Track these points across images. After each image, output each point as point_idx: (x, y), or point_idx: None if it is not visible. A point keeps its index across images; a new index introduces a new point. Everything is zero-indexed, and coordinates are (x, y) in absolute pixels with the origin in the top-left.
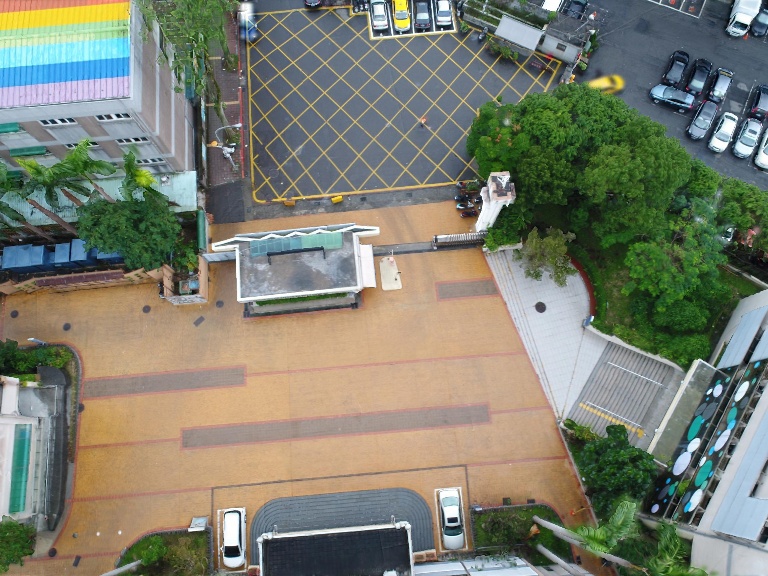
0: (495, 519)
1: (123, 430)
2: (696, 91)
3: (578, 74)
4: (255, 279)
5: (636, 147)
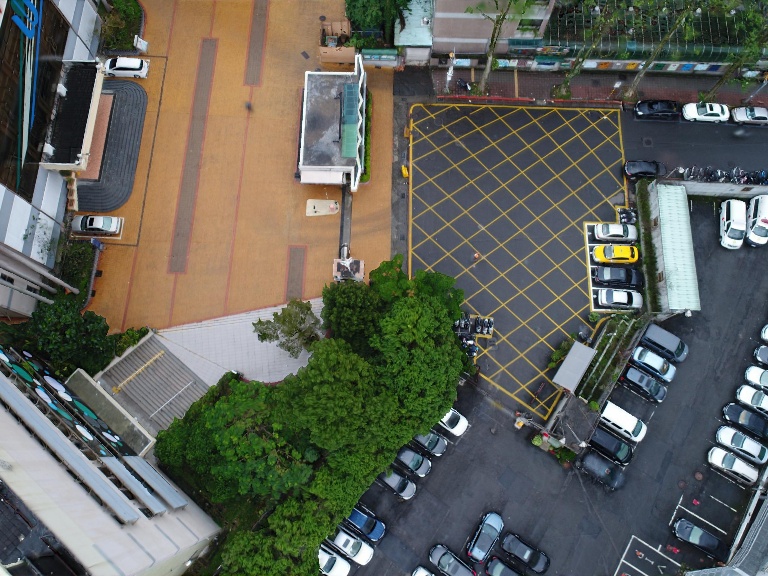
0: (83, 256)
1: (226, 0)
2: (490, 567)
3: (528, 435)
4: (324, 86)
5: (357, 393)
